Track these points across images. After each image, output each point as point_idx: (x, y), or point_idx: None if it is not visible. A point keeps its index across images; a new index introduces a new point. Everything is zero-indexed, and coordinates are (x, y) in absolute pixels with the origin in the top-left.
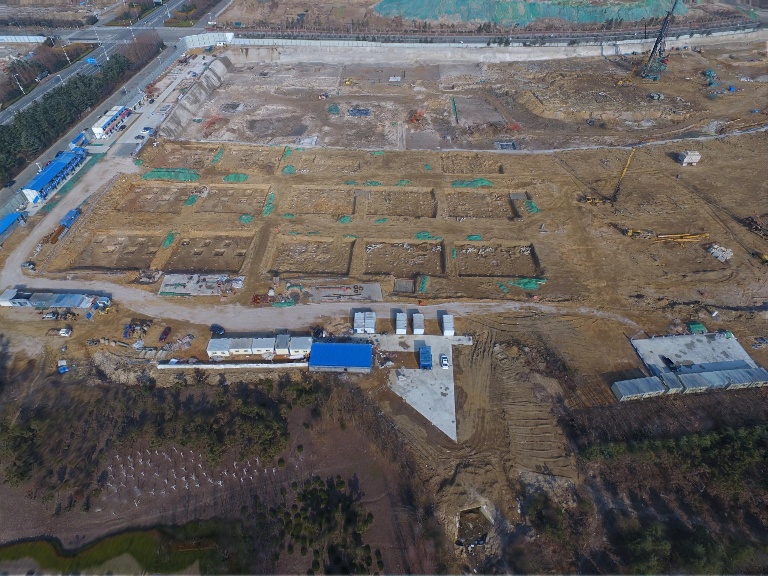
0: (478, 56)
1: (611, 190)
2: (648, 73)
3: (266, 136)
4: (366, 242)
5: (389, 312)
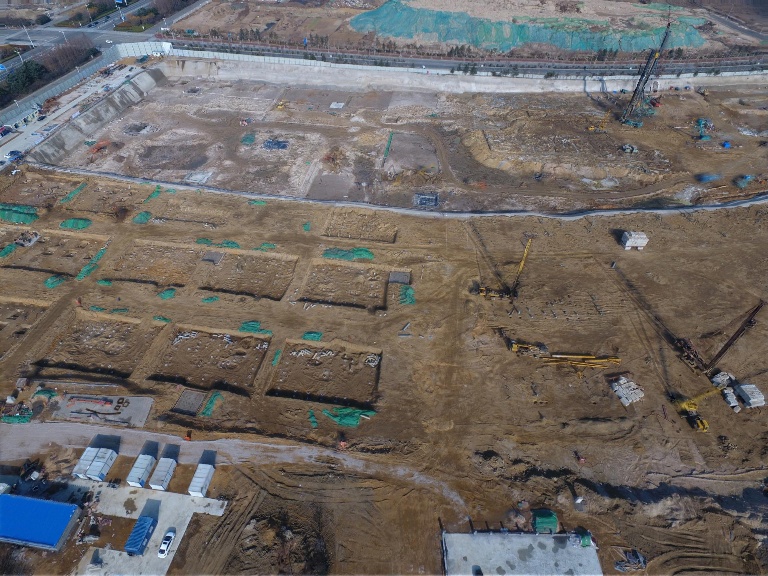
0: (439, 84)
1: (519, 278)
2: (631, 117)
3: (157, 167)
4: (180, 328)
5: (140, 447)
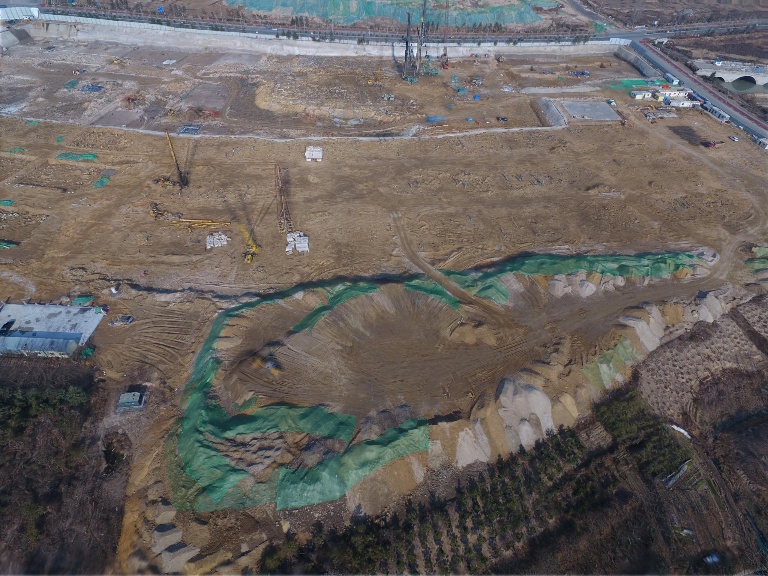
0: (266, 47)
1: (202, 175)
2: (415, 76)
3: None
4: None
5: None
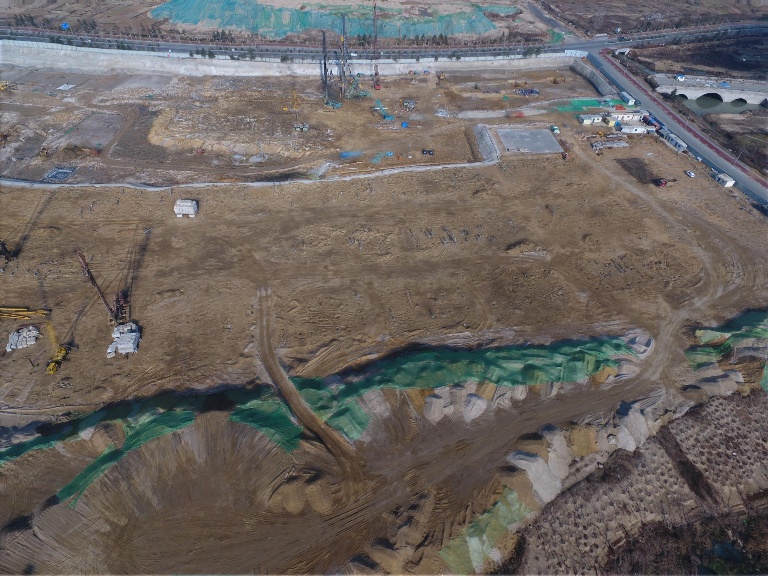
0: (179, 67)
1: (41, 241)
2: (341, 99)
3: None
4: None
5: None
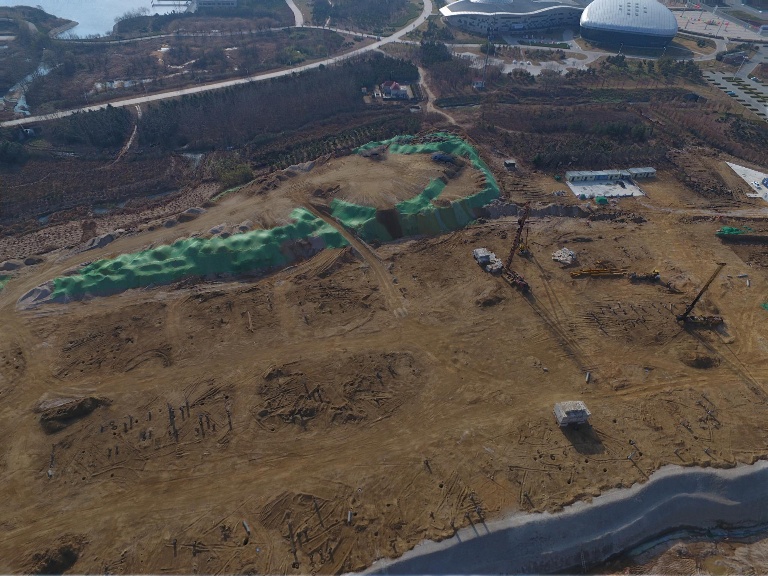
0: None
1: (685, 346)
2: None
3: None
4: None
5: None
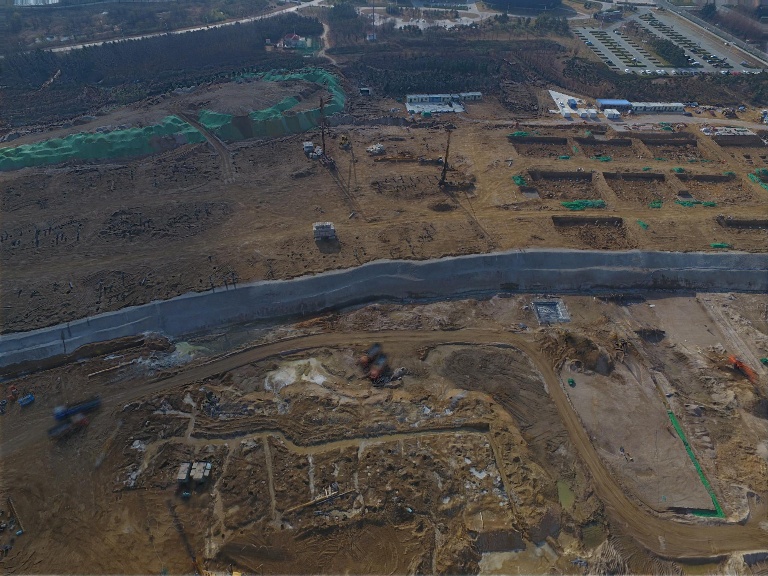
0: None
1: (436, 199)
2: None
3: None
4: None
5: (601, 120)
